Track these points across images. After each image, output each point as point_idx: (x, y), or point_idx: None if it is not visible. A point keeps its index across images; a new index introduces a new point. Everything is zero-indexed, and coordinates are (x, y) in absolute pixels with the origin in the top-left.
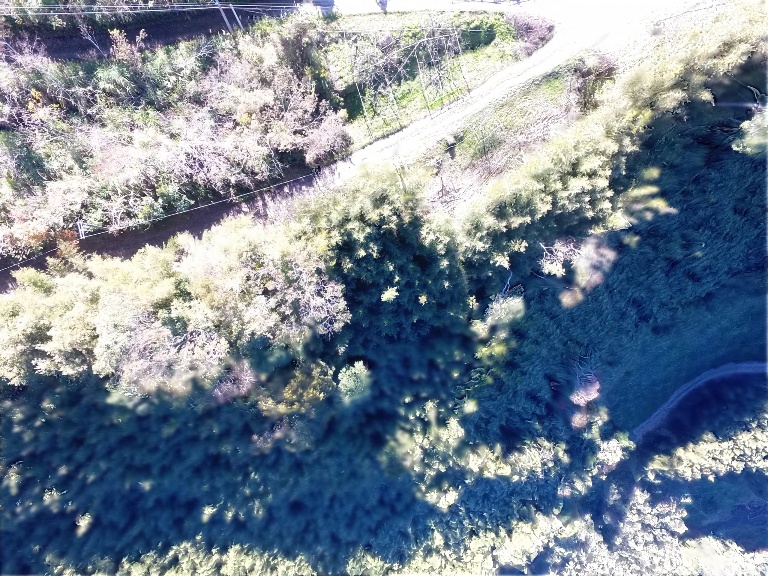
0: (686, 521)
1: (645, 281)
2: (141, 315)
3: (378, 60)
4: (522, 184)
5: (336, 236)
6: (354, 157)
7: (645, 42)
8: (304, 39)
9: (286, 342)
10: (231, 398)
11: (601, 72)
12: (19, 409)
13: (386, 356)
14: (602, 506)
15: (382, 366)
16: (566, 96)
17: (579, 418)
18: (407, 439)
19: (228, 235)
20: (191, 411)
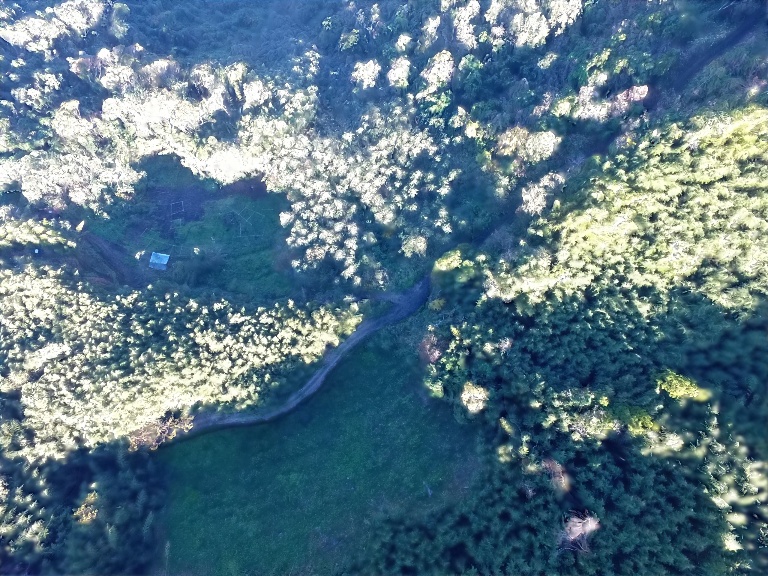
0: (248, 199)
1: None
2: None
3: None
4: None
5: None
6: None
7: None
8: None
9: None
10: None
11: None
12: None
13: None
14: None
15: None
16: None
17: None
18: (760, 485)
19: None
20: None
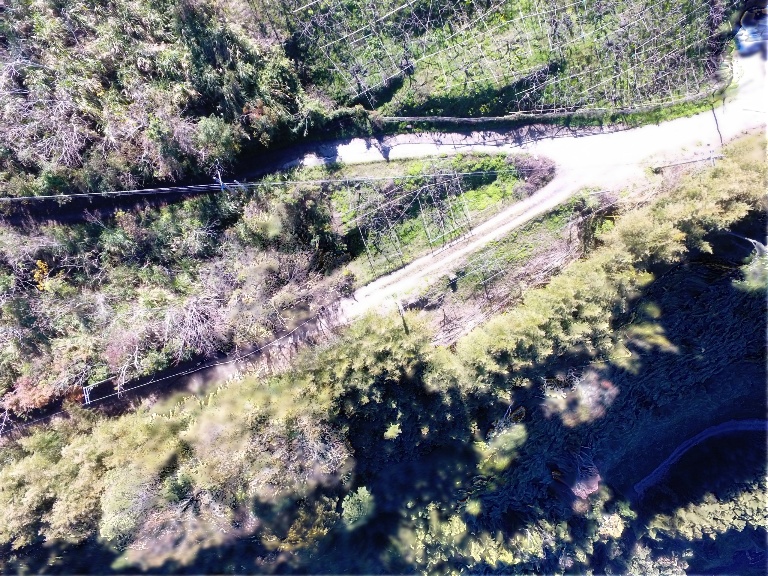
0: None
1: (645, 377)
2: (148, 483)
3: (381, 204)
4: (523, 327)
5: (340, 389)
6: (357, 294)
7: (644, 188)
8: (308, 201)
9: (290, 485)
10: (236, 533)
11: (601, 210)
12: (27, 562)
13: (389, 474)
14: (604, 555)
15: (385, 482)
16: (566, 248)
17: (580, 505)
18: (409, 534)
19: (234, 398)
20: (196, 545)
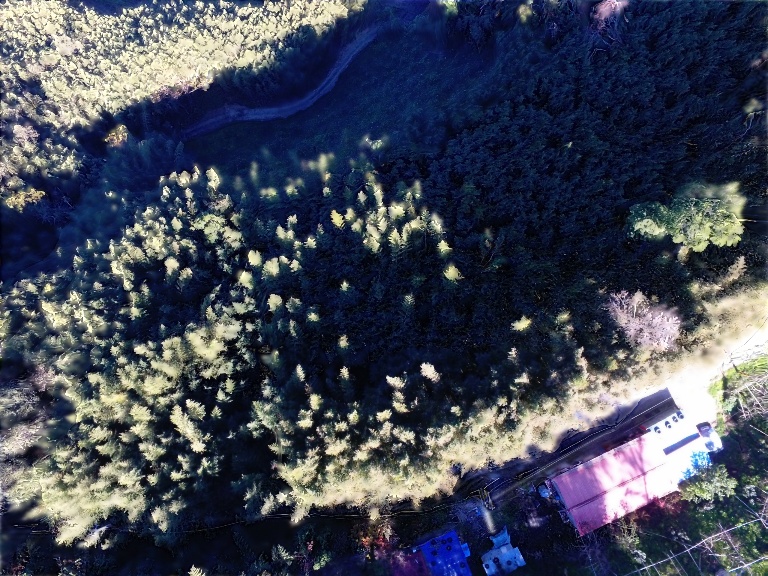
0: None
1: None
2: None
3: None
4: None
5: None
6: None
7: None
8: None
9: None
10: None
11: None
12: None
13: None
14: None
15: None
16: None
17: None
18: None
19: None
20: None
